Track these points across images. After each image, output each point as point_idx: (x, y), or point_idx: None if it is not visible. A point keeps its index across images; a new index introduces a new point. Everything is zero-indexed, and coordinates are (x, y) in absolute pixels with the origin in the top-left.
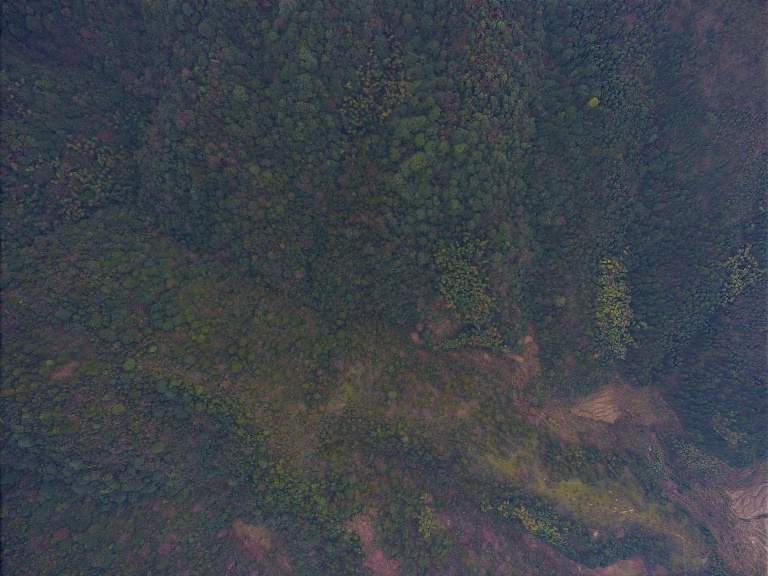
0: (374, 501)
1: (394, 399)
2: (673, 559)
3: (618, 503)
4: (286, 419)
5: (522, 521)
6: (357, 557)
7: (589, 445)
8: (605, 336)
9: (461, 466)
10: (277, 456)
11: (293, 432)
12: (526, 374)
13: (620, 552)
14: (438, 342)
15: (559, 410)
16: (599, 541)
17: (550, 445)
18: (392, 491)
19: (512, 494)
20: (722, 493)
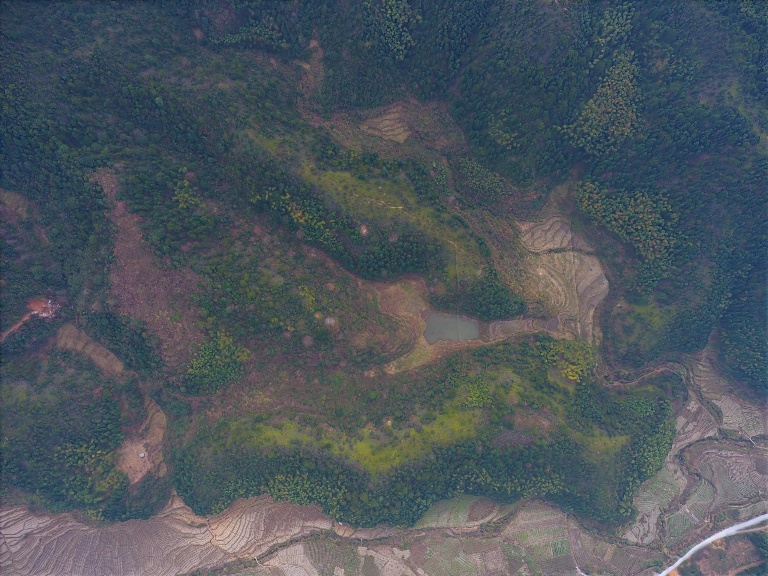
0: (124, 161)
1: (154, 66)
2: (448, 270)
3: (385, 197)
4: (23, 51)
5: (290, 213)
6: (100, 210)
7: (370, 153)
8: (375, 21)
9: (225, 146)
10: (7, 81)
11: (29, 64)
12: (312, 81)
13: (393, 257)
14: (219, 37)
15: (346, 123)
16: (368, 239)
17: (326, 145)
18: (147, 158)
19: (274, 175)
20: (512, 223)
